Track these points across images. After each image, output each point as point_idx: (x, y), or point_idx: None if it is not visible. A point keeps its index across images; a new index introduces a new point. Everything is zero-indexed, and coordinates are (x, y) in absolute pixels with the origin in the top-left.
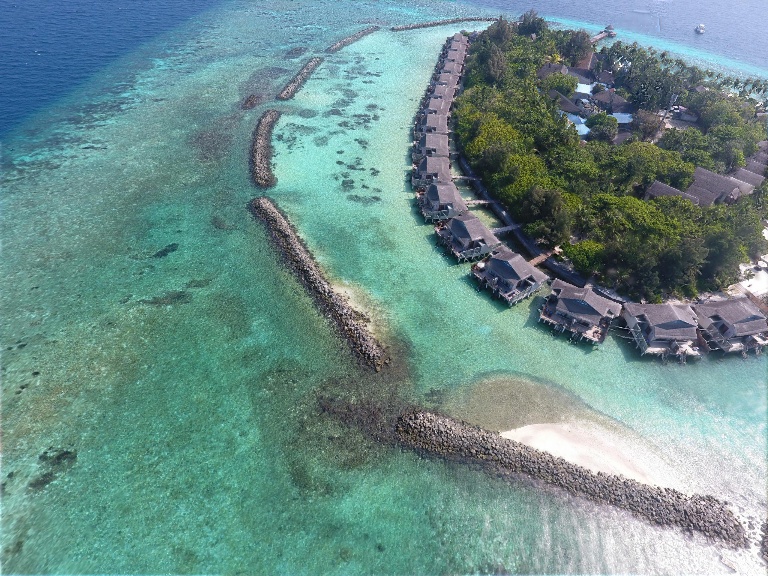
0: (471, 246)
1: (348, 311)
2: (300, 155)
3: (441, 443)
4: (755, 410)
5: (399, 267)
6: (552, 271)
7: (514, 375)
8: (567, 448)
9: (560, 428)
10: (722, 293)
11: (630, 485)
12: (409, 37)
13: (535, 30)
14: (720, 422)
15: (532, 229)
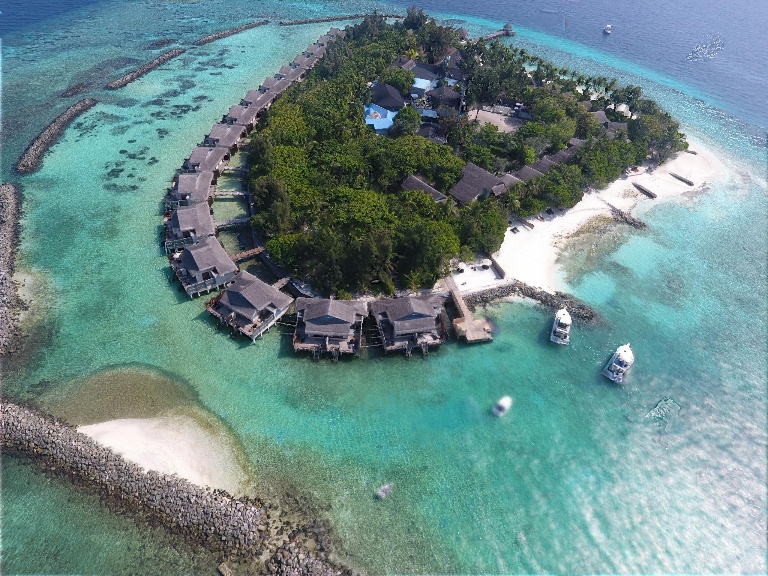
0: (188, 236)
1: (7, 298)
2: (86, 143)
3: (3, 435)
4: (382, 411)
5: (105, 256)
6: (264, 264)
7: (142, 368)
8: (136, 444)
9: (148, 424)
10: (426, 290)
11: (171, 485)
12: (294, 31)
13: (416, 26)
14: (333, 422)
15: (255, 221)
